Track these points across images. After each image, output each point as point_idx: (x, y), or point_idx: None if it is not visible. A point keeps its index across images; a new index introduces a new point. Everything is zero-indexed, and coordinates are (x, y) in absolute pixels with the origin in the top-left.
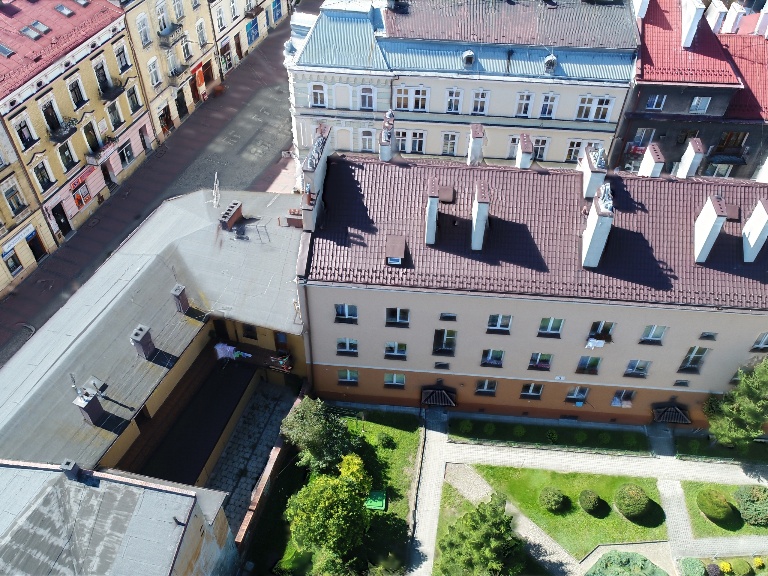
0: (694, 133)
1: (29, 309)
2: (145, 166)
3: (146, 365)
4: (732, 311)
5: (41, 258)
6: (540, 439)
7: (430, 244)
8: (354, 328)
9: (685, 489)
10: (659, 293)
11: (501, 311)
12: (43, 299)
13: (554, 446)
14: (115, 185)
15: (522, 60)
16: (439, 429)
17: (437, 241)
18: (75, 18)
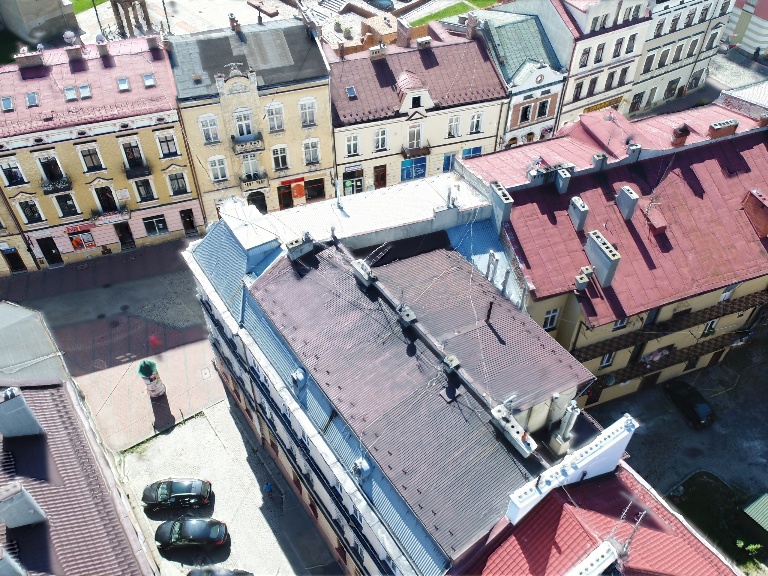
0: None
1: None
2: (176, 243)
3: None
4: None
5: (20, 270)
6: None
7: None
8: None
9: None
10: None
11: None
12: None
13: None
14: (134, 245)
15: (341, 433)
16: None
17: None
18: (126, 95)
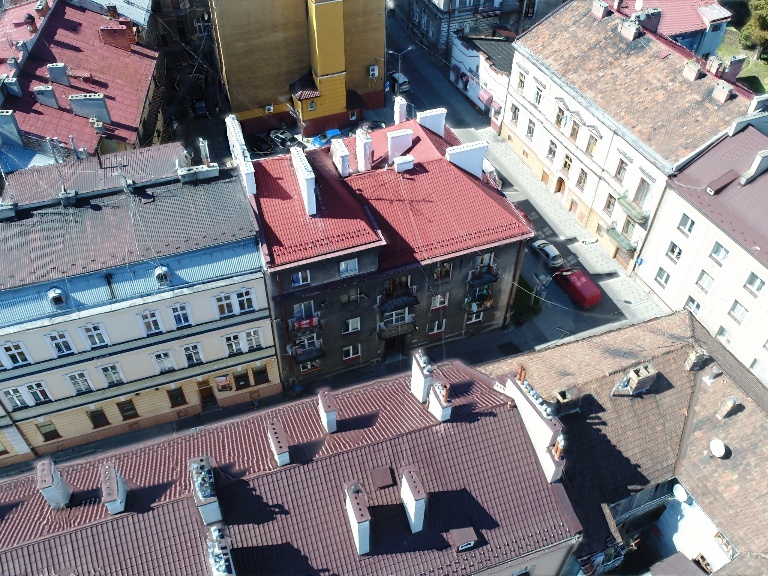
0: (355, 291)
1: None
2: None
3: None
4: None
5: None
6: None
7: None
8: None
9: None
10: None
11: None
12: None
13: None
14: None
15: (126, 281)
16: None
17: None
18: None
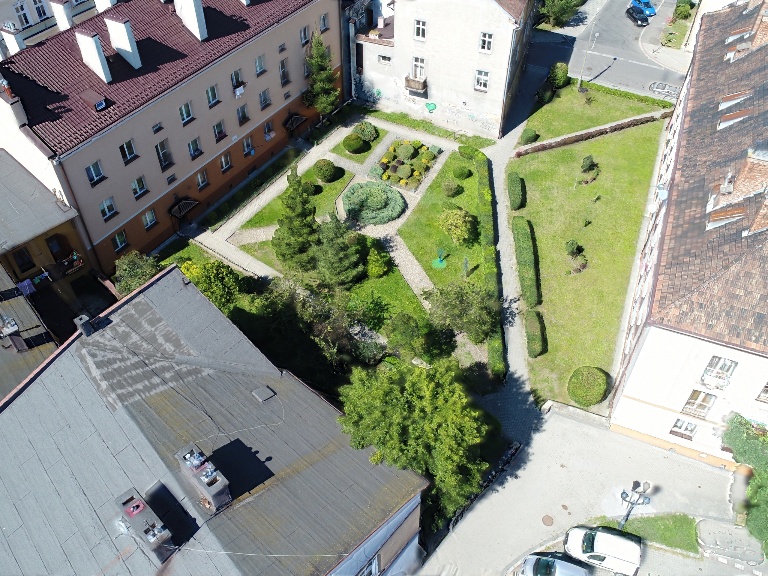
0: None
1: None
2: None
3: (4, 305)
4: (284, 20)
5: None
6: (253, 191)
7: (110, 82)
8: (107, 184)
9: (335, 153)
10: (247, 32)
11: (183, 101)
12: None
13: (263, 187)
14: None
15: None
16: (199, 233)
17: (112, 77)
18: None
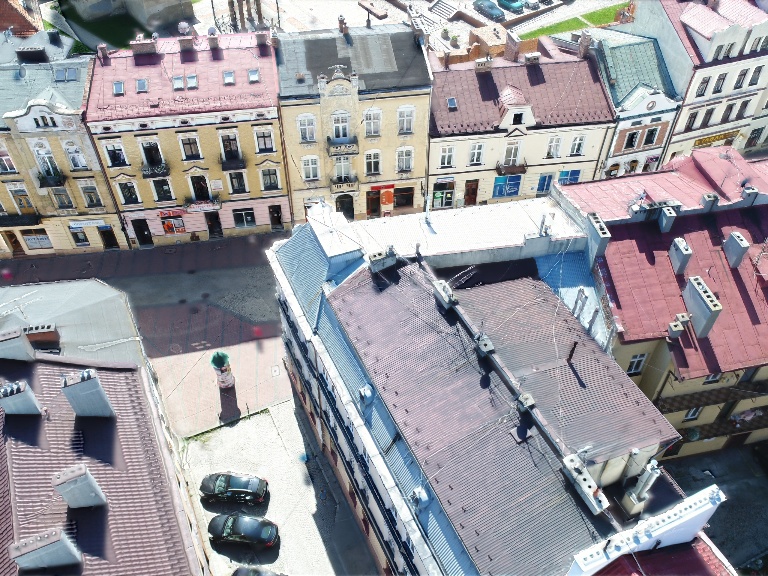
0: None
1: (56, 275)
2: (262, 237)
3: None
4: None
5: (113, 247)
6: None
7: None
8: None
9: None
10: None
11: None
12: (69, 276)
13: None
14: (221, 235)
15: None
16: None
17: None
18: (230, 88)
